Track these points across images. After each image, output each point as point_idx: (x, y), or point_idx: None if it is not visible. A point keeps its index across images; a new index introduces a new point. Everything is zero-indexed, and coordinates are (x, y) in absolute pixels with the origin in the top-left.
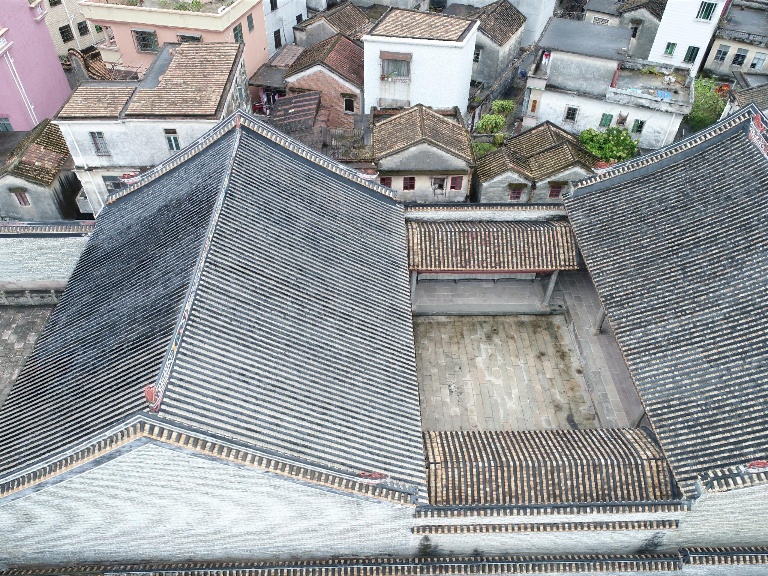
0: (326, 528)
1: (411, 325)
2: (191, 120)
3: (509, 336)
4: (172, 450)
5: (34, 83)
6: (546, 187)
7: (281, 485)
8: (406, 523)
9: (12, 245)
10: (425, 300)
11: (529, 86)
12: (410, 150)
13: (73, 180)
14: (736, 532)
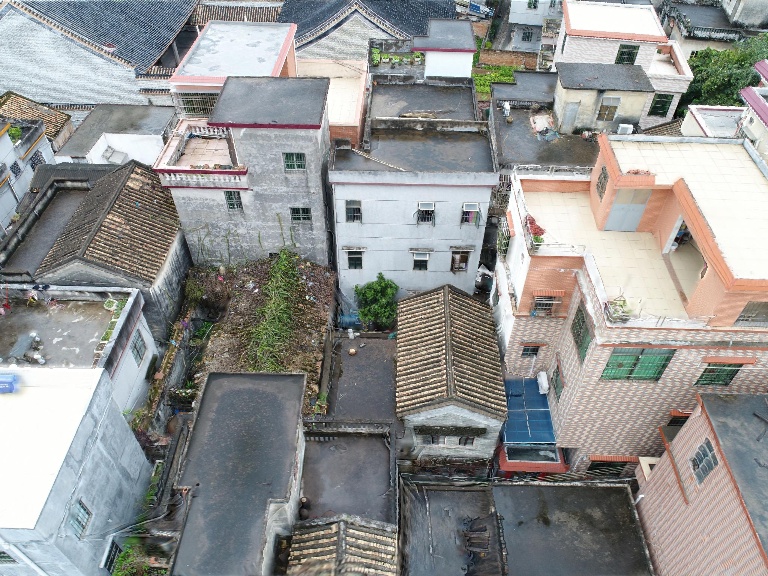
0: (102, 88)
1: (175, 34)
2: None
3: None
4: (21, 15)
5: None
6: None
7: (71, 47)
8: (136, 86)
9: None
10: None
11: None
12: None
13: None
14: None
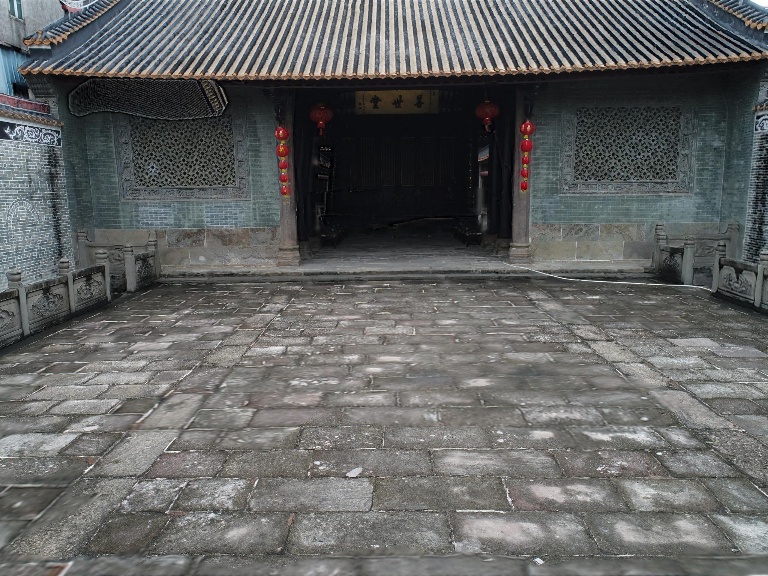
0: None
1: None
2: None
3: None
4: None
5: None
6: None
7: None
8: None
9: None
10: None
11: None
12: None
13: None
14: None
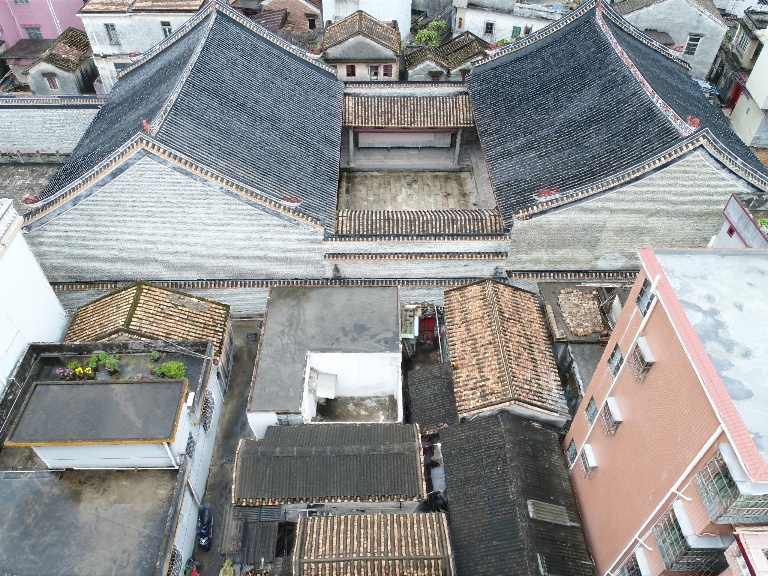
0: (266, 254)
1: (339, 150)
2: (181, 14)
3: (425, 184)
4: (160, 163)
5: (59, 2)
6: (458, 75)
7: (232, 203)
8: (320, 250)
9: (45, 115)
10: (363, 161)
11: (454, 5)
12: (349, 41)
13: (91, 74)
14: (552, 269)
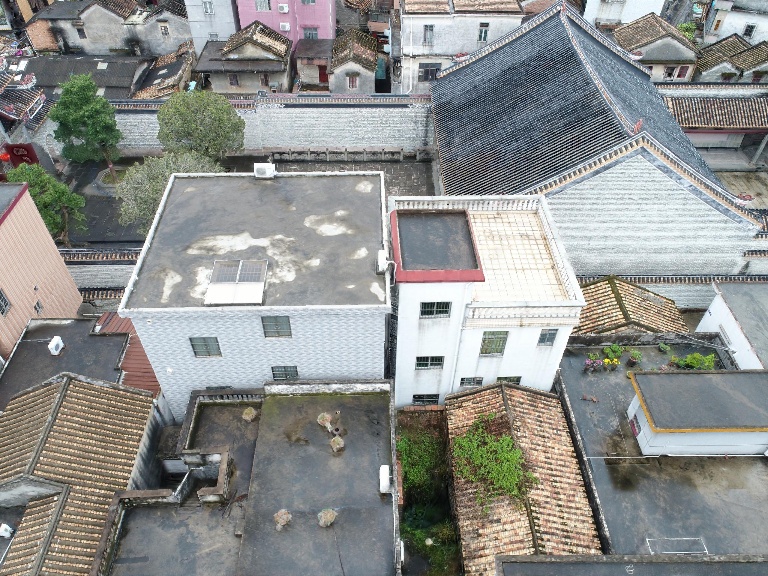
0: (689, 251)
1: None
2: (504, 15)
3: (730, 183)
4: (648, 162)
5: (331, 3)
6: (750, 76)
7: (690, 201)
8: (743, 247)
9: (353, 114)
10: None
11: (717, 8)
12: (656, 43)
13: None
14: None
